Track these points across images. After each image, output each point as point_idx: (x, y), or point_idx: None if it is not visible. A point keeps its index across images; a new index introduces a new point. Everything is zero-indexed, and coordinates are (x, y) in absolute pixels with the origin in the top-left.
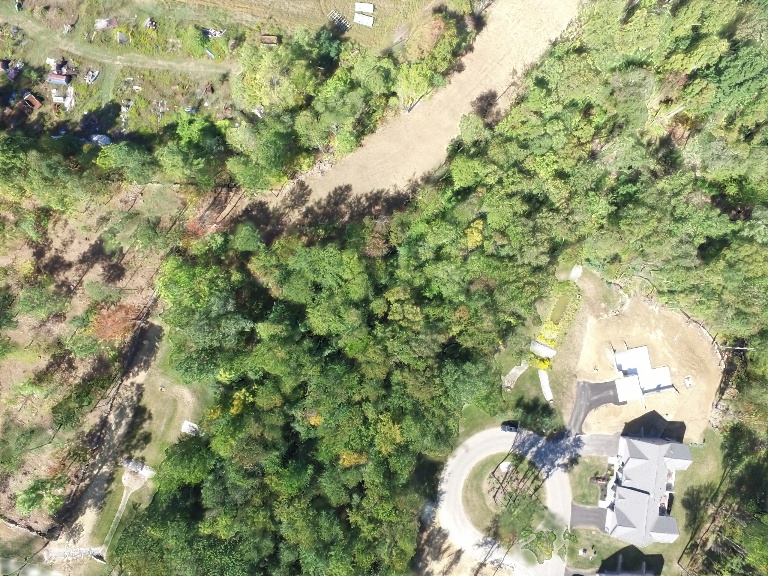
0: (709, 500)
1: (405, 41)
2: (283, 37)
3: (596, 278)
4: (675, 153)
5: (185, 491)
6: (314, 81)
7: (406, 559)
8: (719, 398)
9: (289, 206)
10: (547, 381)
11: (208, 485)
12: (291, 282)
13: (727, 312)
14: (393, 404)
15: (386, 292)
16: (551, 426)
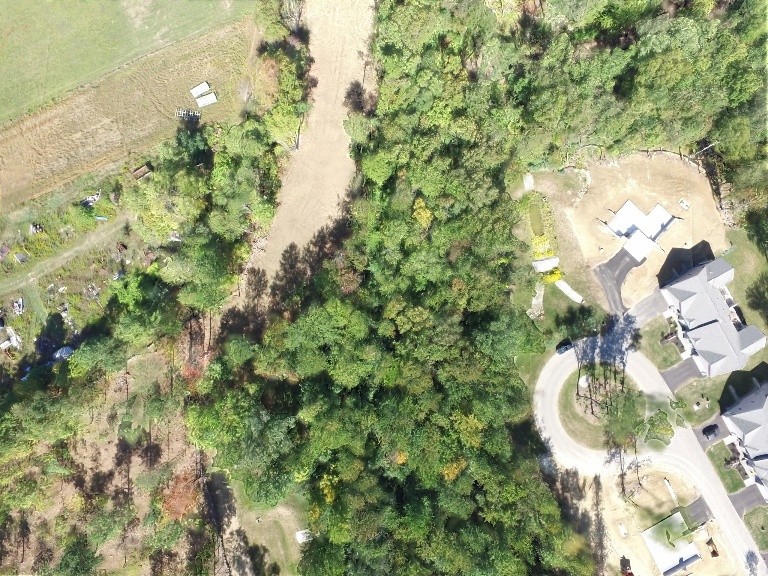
0: None
1: (252, 96)
2: (151, 162)
3: (548, 174)
4: (539, 25)
5: None
6: (202, 181)
7: (556, 520)
8: (719, 200)
9: (255, 296)
10: (568, 287)
11: (352, 574)
12: (300, 361)
13: (674, 128)
14: (455, 400)
15: (384, 313)
16: (598, 322)
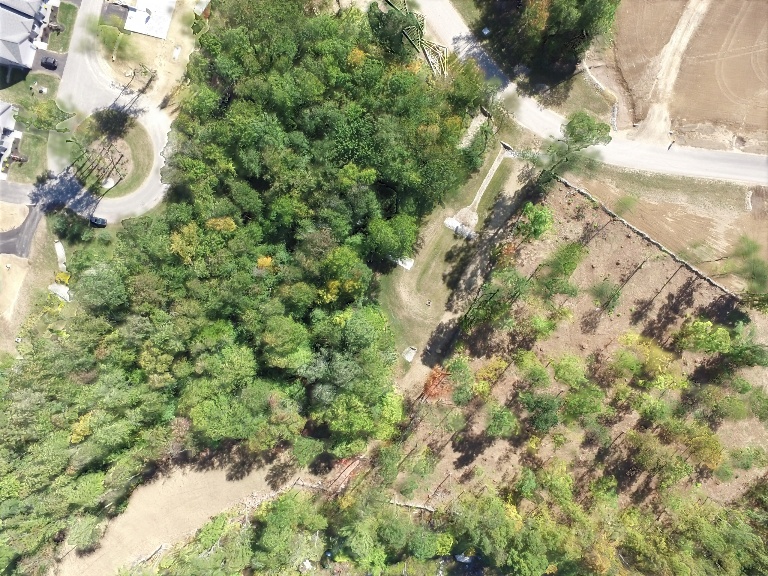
0: None
1: None
2: None
3: None
4: None
5: None
6: None
7: (180, 123)
8: None
9: (289, 467)
10: (60, 261)
11: (378, 212)
12: None
13: None
14: (183, 271)
15: None
16: None
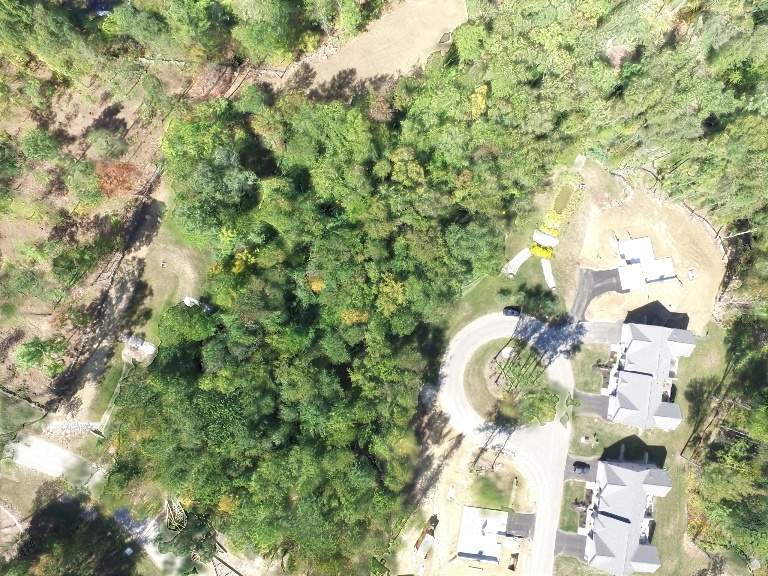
0: (712, 393)
1: None
2: None
3: (599, 168)
4: None
5: (185, 354)
6: None
7: (407, 417)
8: (722, 291)
9: (293, 88)
10: (550, 269)
11: (208, 349)
12: (295, 140)
13: (731, 187)
14: (396, 267)
15: (390, 155)
16: (554, 312)
